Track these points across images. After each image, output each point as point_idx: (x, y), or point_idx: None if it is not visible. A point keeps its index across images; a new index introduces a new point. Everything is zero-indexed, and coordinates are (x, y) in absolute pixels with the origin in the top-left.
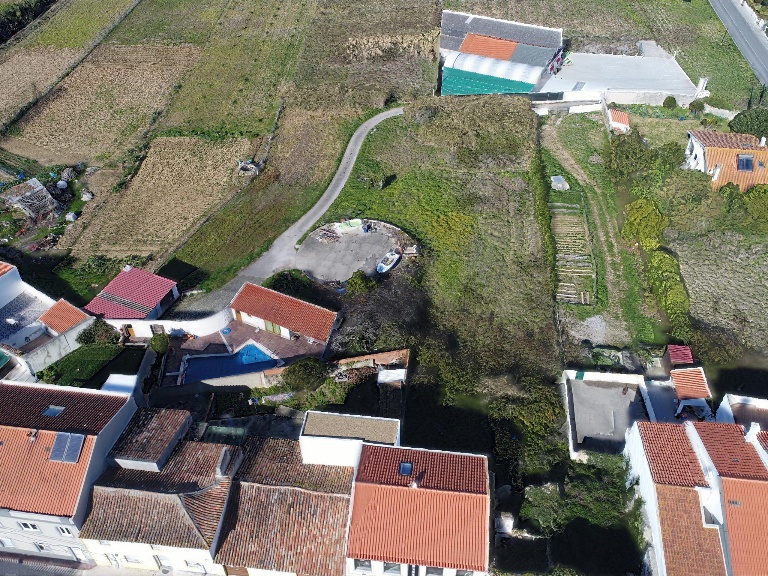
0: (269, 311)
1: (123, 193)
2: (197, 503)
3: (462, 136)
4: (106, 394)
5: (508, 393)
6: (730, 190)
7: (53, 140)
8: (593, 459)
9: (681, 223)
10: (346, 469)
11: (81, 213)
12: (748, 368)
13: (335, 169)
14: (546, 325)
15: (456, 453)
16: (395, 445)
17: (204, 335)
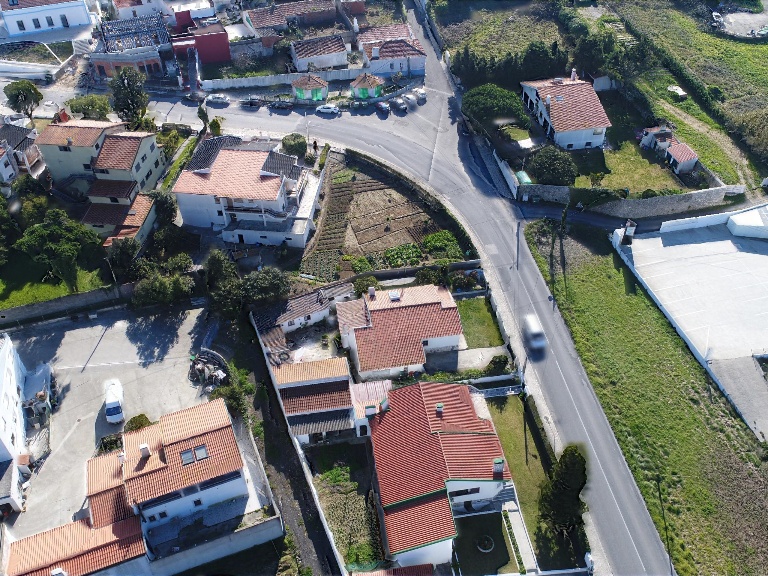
0: None
1: None
2: None
3: None
4: None
5: None
6: None
7: None
8: None
9: None
10: None
11: None
12: (526, 5)
13: None
14: (618, 8)
15: None
16: None
17: None
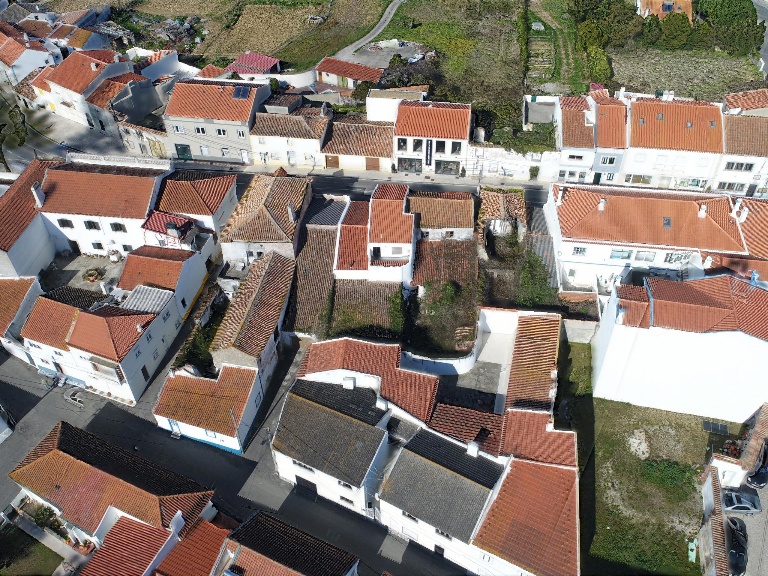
0: (341, 71)
1: (230, 31)
2: (312, 122)
3: (470, 0)
4: (254, 83)
5: (488, 101)
6: (651, 17)
7: (172, 6)
8: (536, 127)
9: (616, 39)
10: (392, 122)
11: (204, 39)
12: None
13: (378, 20)
14: None
15: (454, 103)
16: (420, 100)
17: (299, 87)
